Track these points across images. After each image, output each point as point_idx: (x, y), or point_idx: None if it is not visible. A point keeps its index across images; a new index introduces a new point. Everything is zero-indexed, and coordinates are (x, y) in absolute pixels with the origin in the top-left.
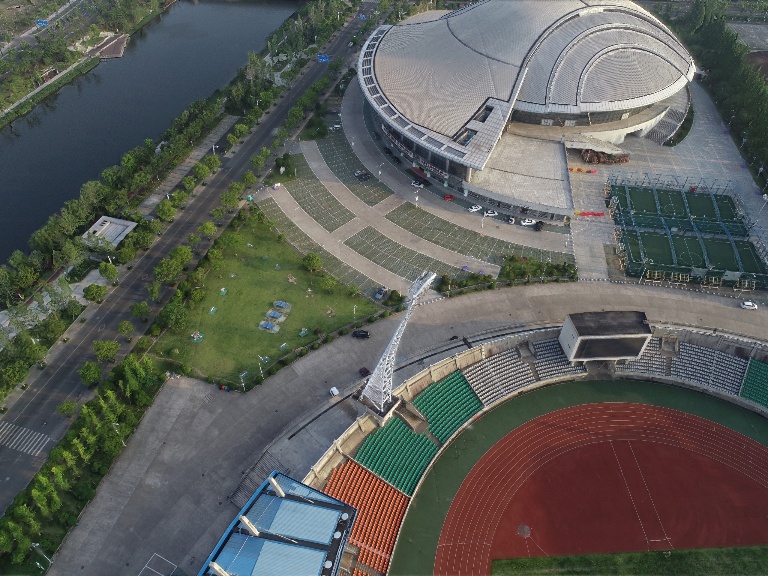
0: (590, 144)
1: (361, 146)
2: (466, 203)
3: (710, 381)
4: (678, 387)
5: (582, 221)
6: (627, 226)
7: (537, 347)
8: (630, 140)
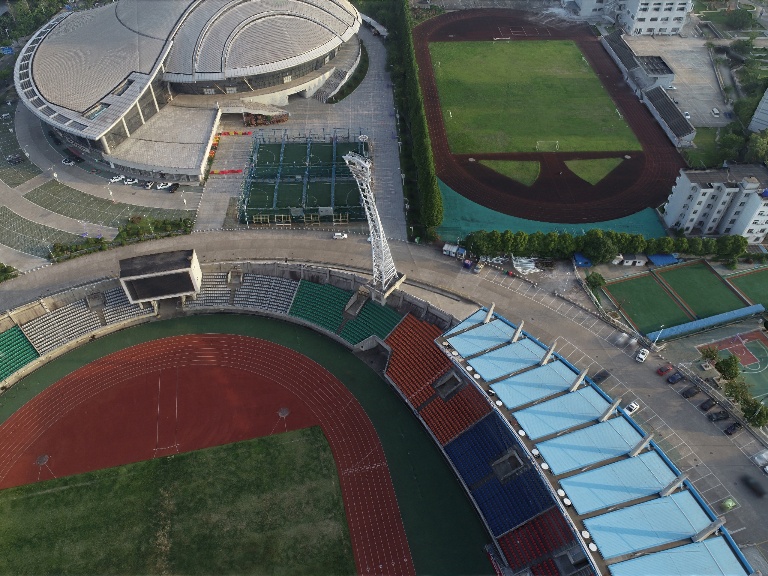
0: (244, 108)
1: (26, 132)
2: (111, 175)
3: (266, 305)
4: (245, 314)
5: (219, 179)
6: (260, 179)
7: (107, 295)
8: (297, 101)
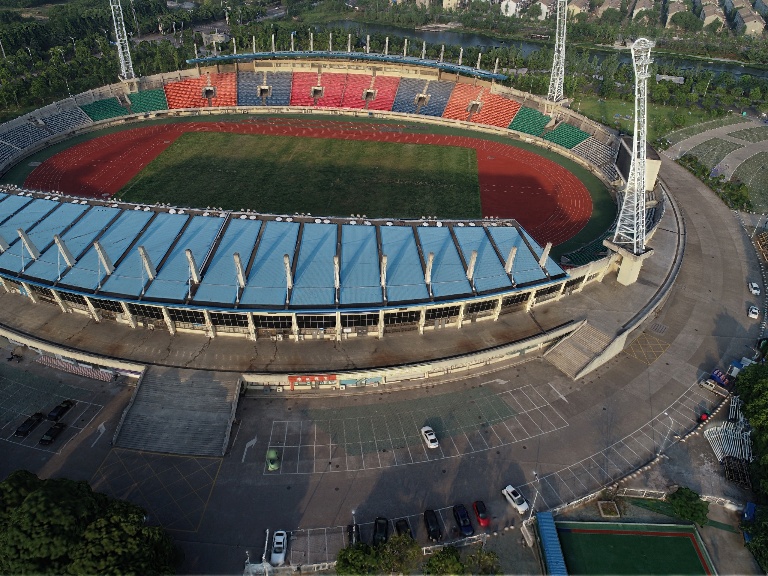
0: None
1: None
2: None
3: None
4: None
5: None
6: None
7: None
8: None
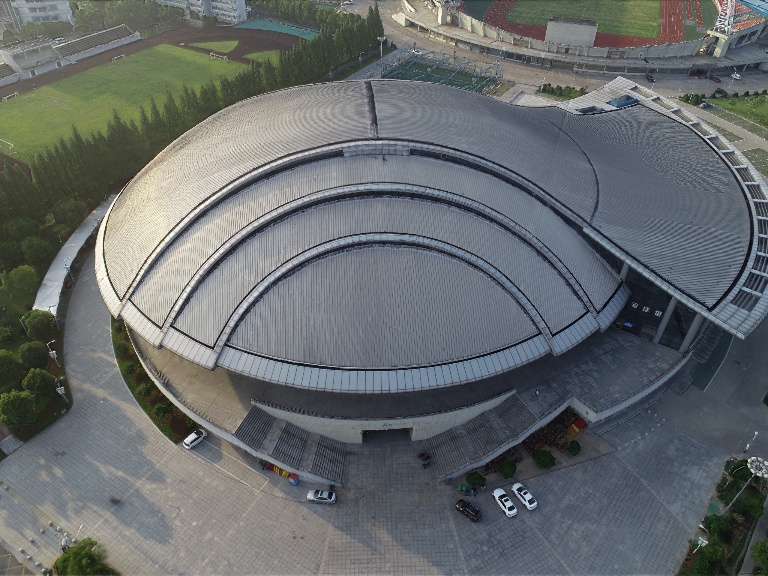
0: None
1: None
2: None
3: None
4: None
5: None
6: None
7: None
8: None
